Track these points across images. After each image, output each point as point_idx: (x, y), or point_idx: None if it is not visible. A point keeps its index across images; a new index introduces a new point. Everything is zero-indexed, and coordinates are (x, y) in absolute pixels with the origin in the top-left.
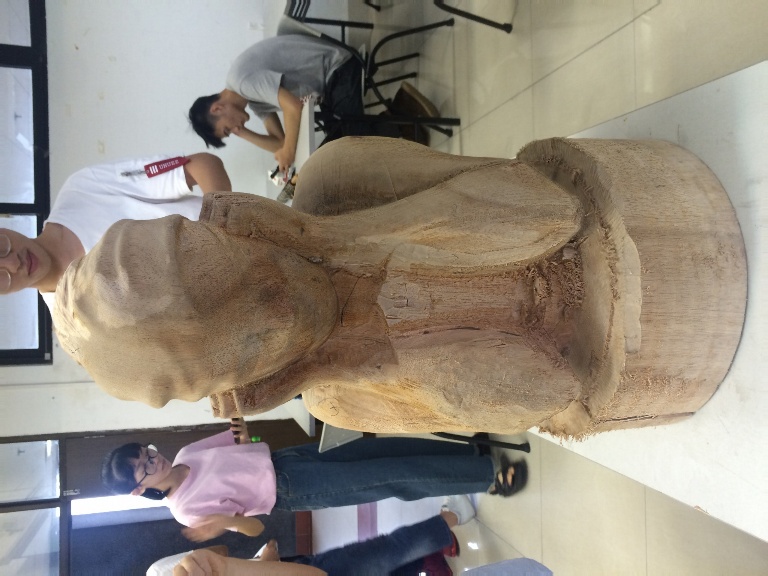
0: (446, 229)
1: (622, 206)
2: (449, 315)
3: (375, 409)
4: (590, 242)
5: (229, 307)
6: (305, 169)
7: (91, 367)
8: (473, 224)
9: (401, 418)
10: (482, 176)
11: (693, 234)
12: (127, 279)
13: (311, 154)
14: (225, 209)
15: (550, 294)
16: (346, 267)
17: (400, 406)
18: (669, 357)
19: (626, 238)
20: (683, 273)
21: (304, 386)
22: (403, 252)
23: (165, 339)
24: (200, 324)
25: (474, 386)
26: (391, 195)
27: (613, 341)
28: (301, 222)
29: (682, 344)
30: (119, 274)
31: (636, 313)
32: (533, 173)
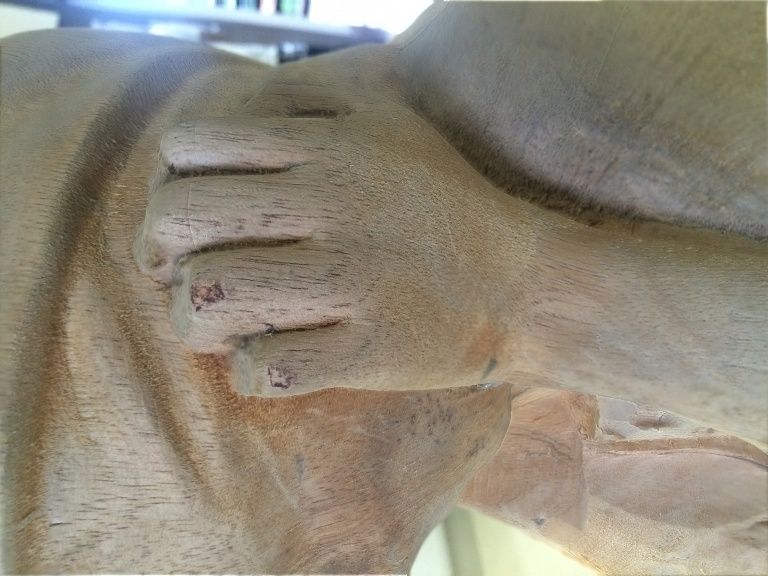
0: None
1: None
2: None
3: None
4: None
5: None
6: None
7: None
8: None
9: None
10: None
11: None
12: None
13: None
14: (230, 333)
15: None
16: None
17: None
18: None
19: None
20: None
21: None
22: None
23: None
24: None
25: None
26: None
27: None
28: (495, 333)
29: None
30: None
31: None
32: None
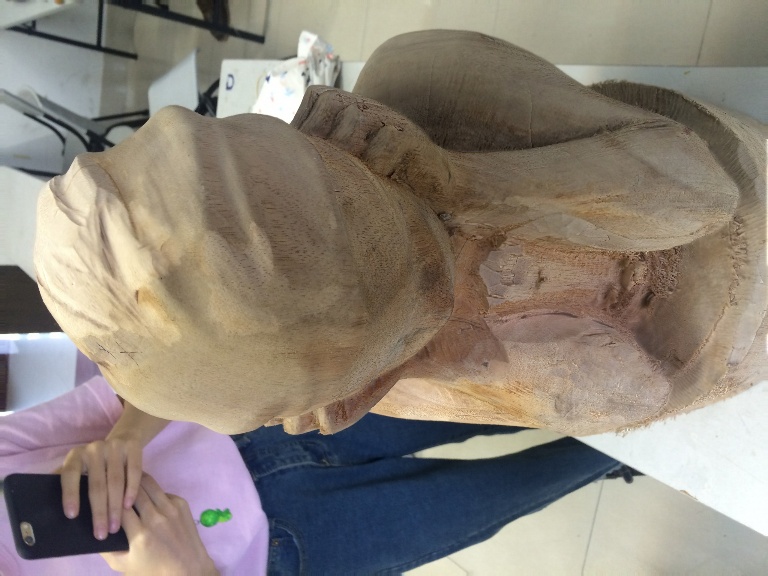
0: (620, 206)
1: None
2: (548, 296)
3: (426, 396)
4: None
5: (396, 302)
6: (396, 62)
7: (150, 382)
8: (650, 204)
9: (456, 409)
10: (662, 141)
11: None
12: (269, 251)
13: (394, 37)
14: (370, 129)
15: None
16: (462, 226)
17: (459, 396)
18: (751, 367)
19: None
20: None
21: None
22: (550, 222)
23: (312, 354)
24: (366, 332)
25: (589, 395)
26: (524, 133)
27: (710, 347)
28: (446, 162)
29: (765, 355)
30: (253, 239)
31: (754, 325)
32: (706, 147)
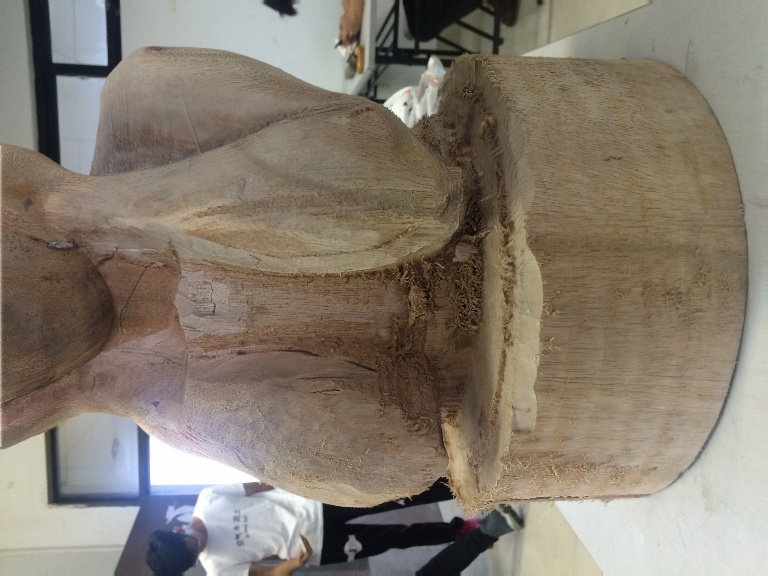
0: (229, 218)
1: (530, 195)
2: (278, 329)
3: None
4: (491, 241)
5: None
6: None
7: None
8: (270, 214)
9: None
10: (296, 132)
11: (653, 249)
12: None
13: None
14: None
15: (432, 311)
16: (121, 253)
17: None
18: (588, 440)
19: (526, 252)
20: (622, 316)
21: (60, 417)
22: (183, 243)
23: None
24: None
25: (279, 452)
26: (193, 145)
27: (503, 404)
28: (30, 189)
29: (611, 424)
30: None
31: (530, 376)
32: (383, 130)
